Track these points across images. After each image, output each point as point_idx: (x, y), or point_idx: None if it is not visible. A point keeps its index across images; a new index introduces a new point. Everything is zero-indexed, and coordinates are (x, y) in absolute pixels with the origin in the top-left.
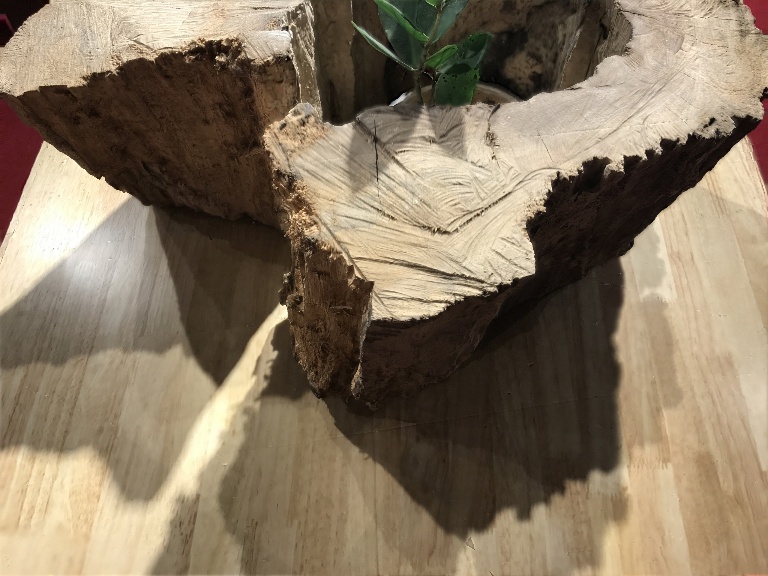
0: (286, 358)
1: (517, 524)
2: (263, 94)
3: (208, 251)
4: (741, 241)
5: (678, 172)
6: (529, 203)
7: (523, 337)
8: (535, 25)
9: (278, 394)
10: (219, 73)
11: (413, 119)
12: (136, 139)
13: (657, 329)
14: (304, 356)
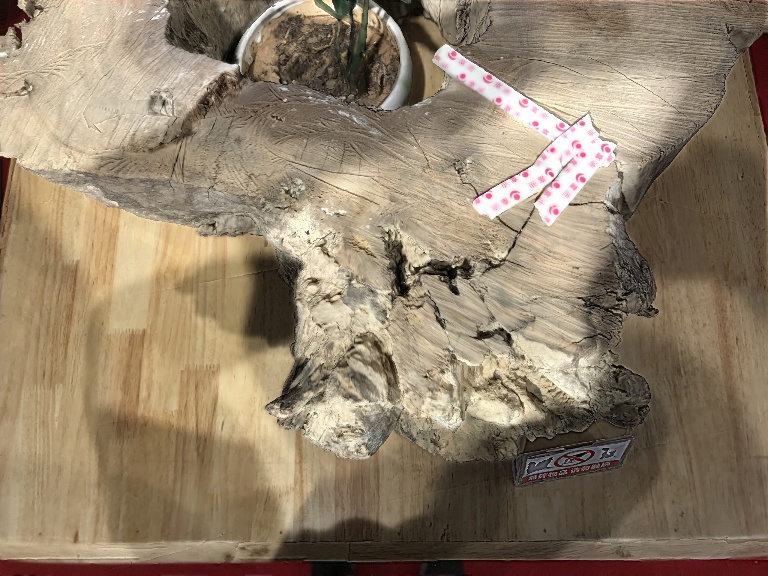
0: None
1: None
2: None
3: None
4: None
5: None
6: None
7: None
8: None
9: None
10: None
11: None
12: None
13: None
14: None
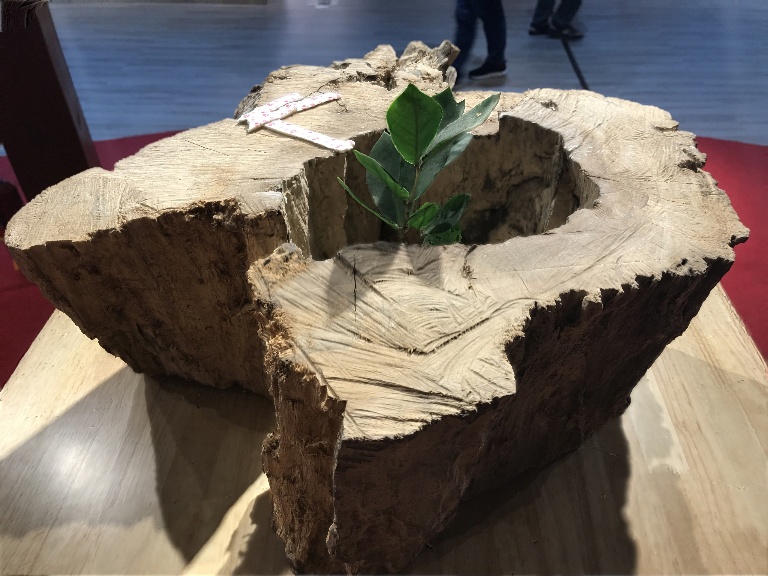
0: (265, 532)
1: None
2: (255, 247)
3: (194, 419)
4: (748, 411)
5: (660, 314)
6: (507, 328)
7: (525, 510)
8: (514, 201)
9: (252, 573)
10: (216, 231)
11: (392, 254)
12: (133, 300)
13: (671, 502)
14: (281, 519)
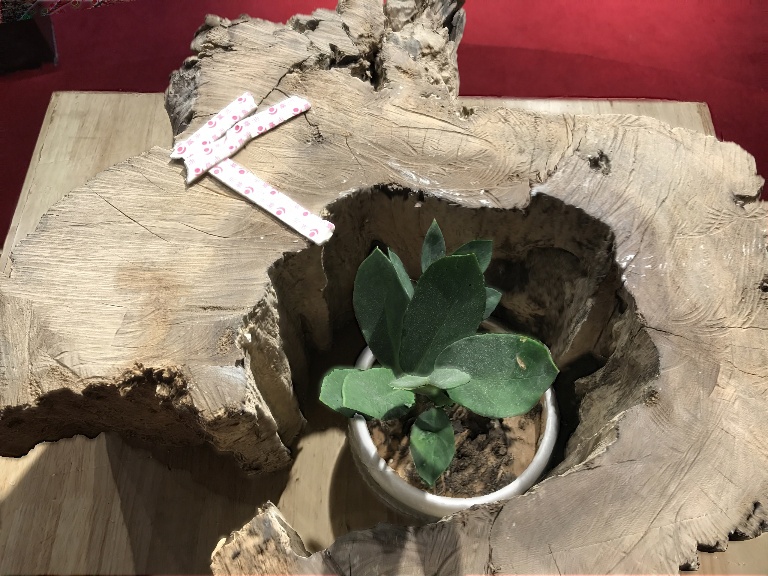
0: None
1: None
2: (215, 434)
3: (167, 486)
4: None
5: None
6: None
7: None
8: (537, 268)
9: None
10: None
11: (397, 550)
12: None
13: None
14: None
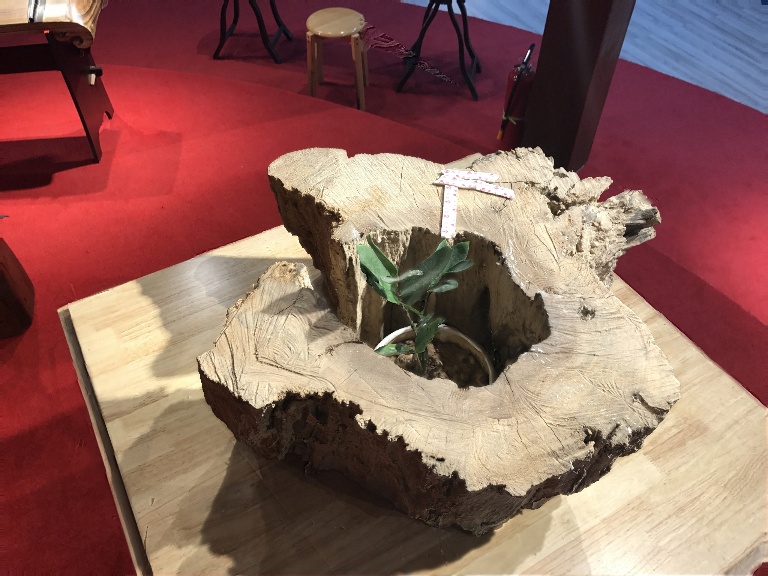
0: None
1: (225, 571)
2: (330, 253)
3: None
4: None
5: None
6: (301, 386)
7: (361, 513)
8: None
9: None
10: None
11: (318, 309)
12: None
13: None
14: None
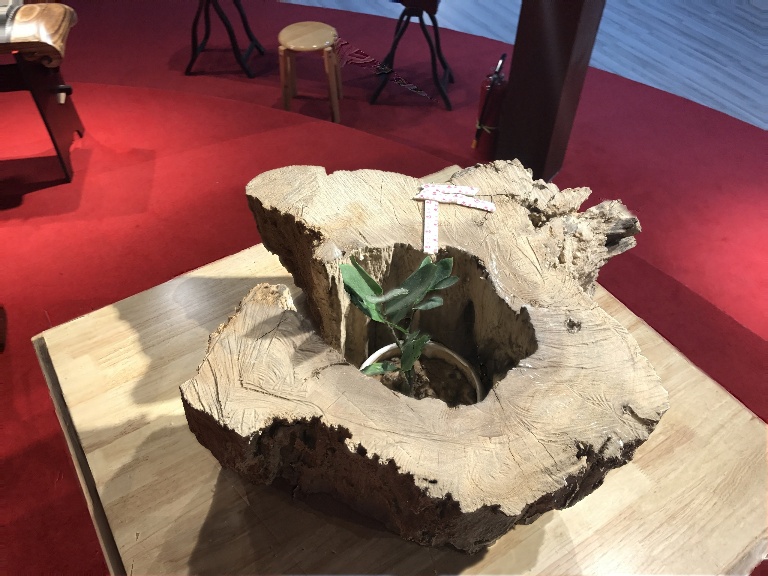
0: None
1: None
2: (312, 272)
3: None
4: None
5: None
6: (288, 412)
7: (352, 536)
8: None
9: None
10: None
11: (302, 331)
12: None
13: None
14: None
